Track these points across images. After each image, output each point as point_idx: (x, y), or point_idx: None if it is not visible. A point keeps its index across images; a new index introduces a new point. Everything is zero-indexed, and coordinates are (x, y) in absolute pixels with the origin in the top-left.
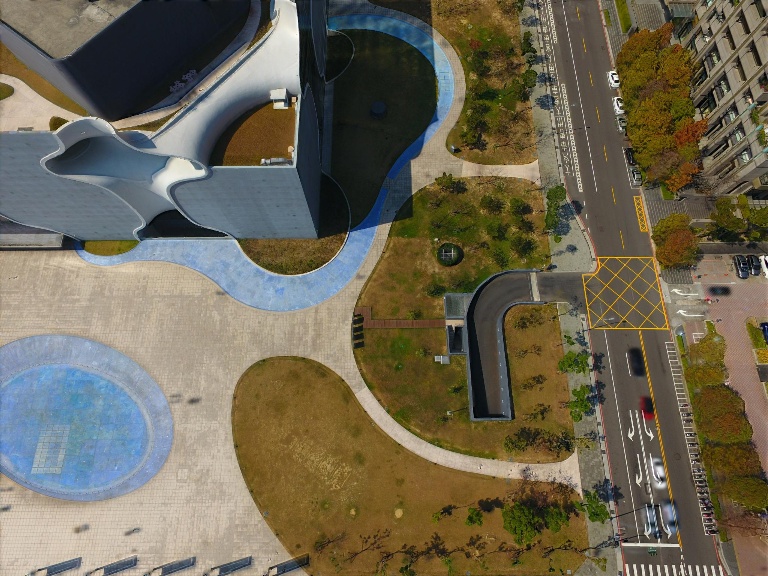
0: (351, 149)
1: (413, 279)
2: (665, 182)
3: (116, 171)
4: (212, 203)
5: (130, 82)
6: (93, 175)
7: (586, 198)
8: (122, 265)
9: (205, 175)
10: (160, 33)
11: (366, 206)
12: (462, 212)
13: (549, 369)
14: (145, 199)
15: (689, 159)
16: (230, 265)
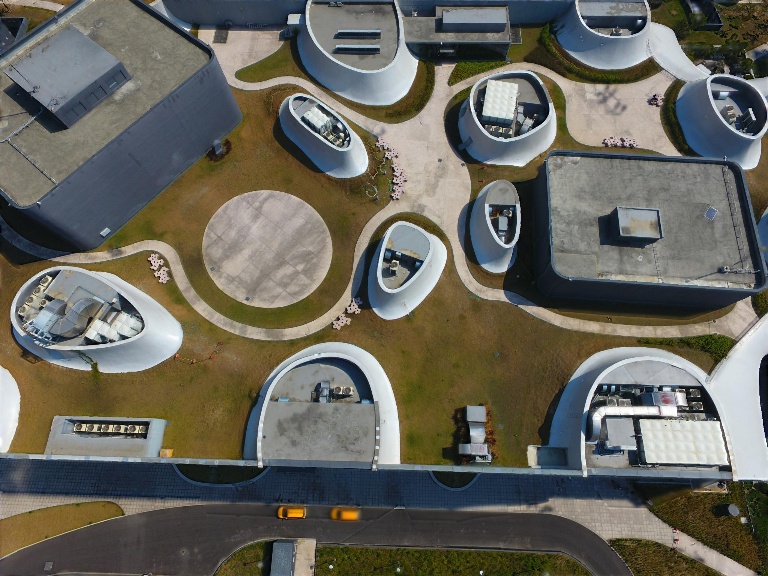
0: None
1: None
2: None
3: None
4: None
5: None
6: None
7: None
8: None
9: None
10: None
11: None
12: None
13: None
14: None
15: None
16: None
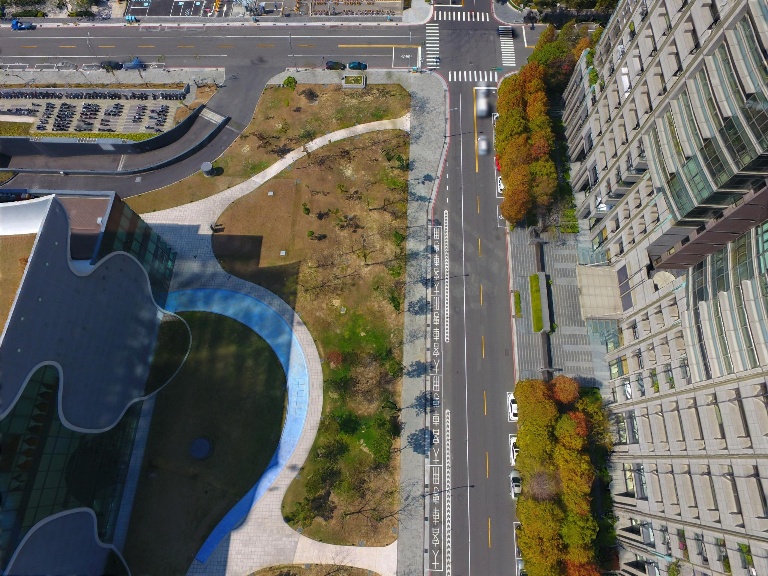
0: (157, 509)
1: None
2: None
3: None
4: None
5: None
6: None
7: None
8: None
9: None
10: None
11: None
12: None
13: None
14: None
15: None
16: None
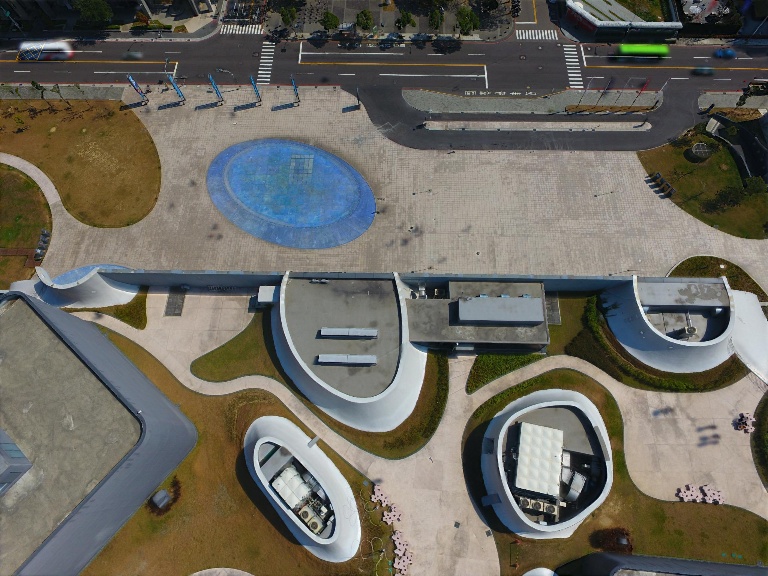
0: None
1: None
2: None
3: None
4: None
5: None
6: None
7: None
8: None
9: None
10: None
11: None
12: None
13: None
14: None
15: None
16: None
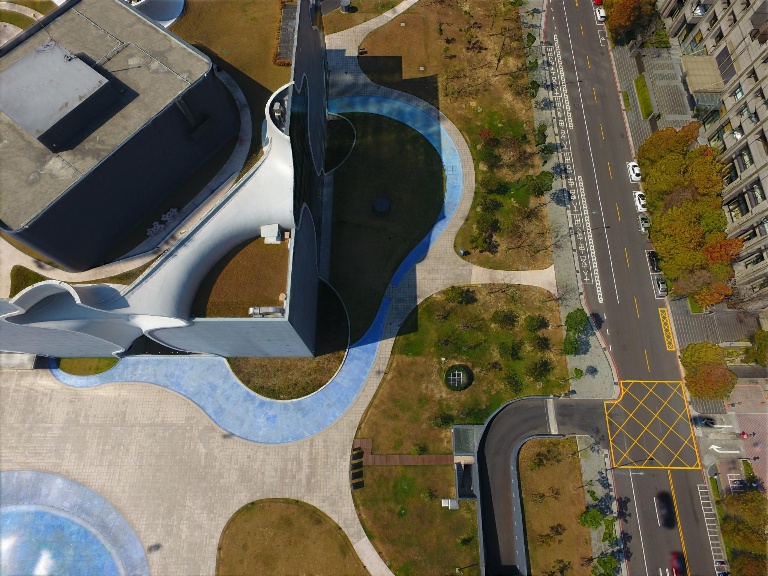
0: (351, 251)
1: (418, 406)
2: (694, 296)
3: (88, 313)
4: (196, 339)
5: (101, 231)
6: (62, 320)
7: (607, 310)
8: (100, 387)
9: (186, 325)
10: (135, 178)
11: (367, 318)
12: (472, 326)
13: (569, 517)
14: (123, 331)
15: (722, 278)
16: (218, 387)
